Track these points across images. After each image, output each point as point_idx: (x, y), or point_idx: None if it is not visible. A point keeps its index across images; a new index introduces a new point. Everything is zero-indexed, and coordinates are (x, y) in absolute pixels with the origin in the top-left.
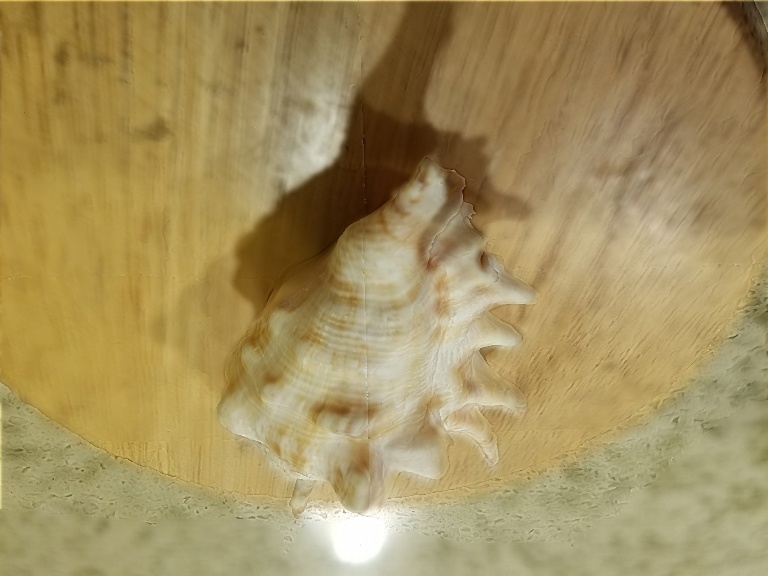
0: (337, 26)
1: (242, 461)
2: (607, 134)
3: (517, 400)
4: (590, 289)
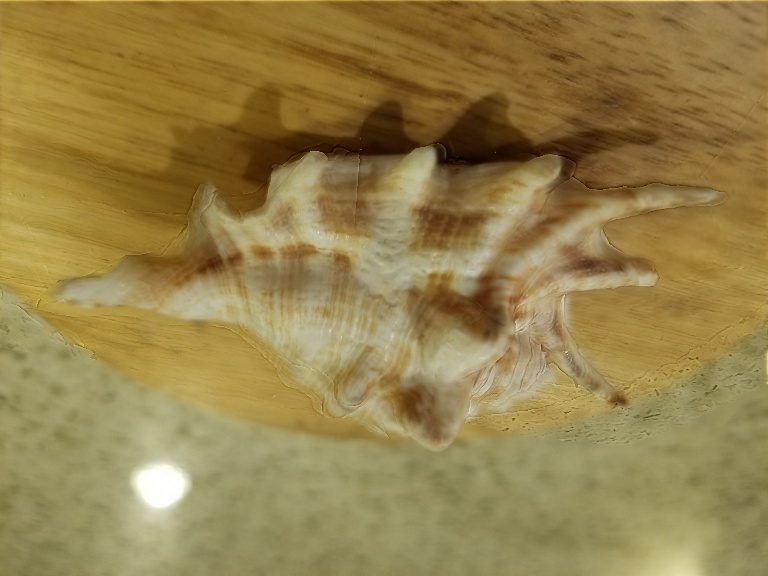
0: (74, 212)
1: (611, 351)
2: (141, 2)
3: (543, 176)
4: (427, 4)
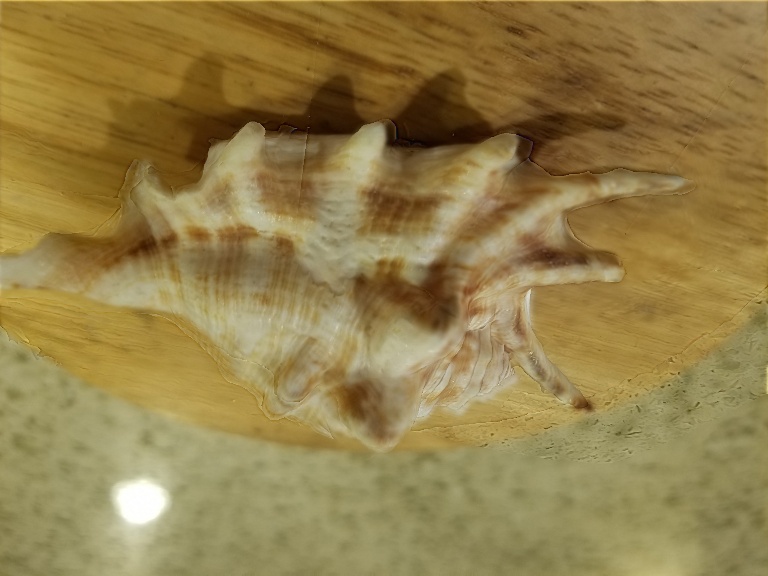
0: (8, 193)
1: (584, 358)
2: None
3: (498, 156)
4: None
